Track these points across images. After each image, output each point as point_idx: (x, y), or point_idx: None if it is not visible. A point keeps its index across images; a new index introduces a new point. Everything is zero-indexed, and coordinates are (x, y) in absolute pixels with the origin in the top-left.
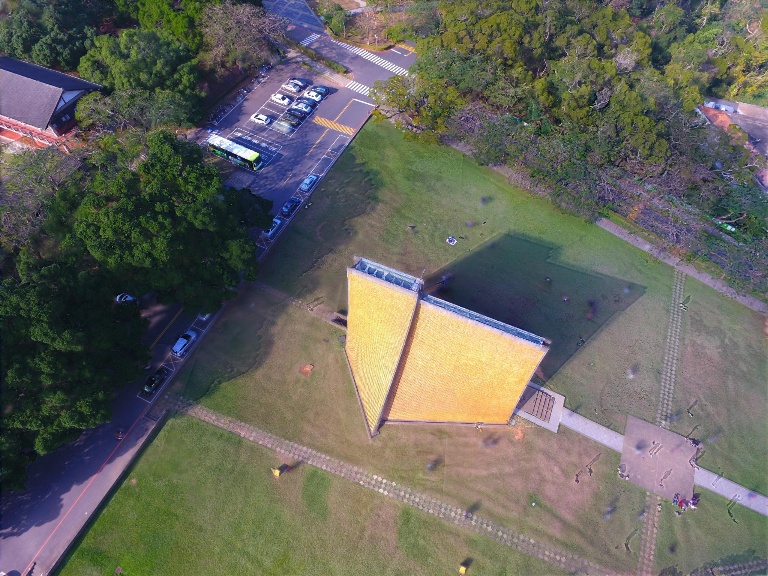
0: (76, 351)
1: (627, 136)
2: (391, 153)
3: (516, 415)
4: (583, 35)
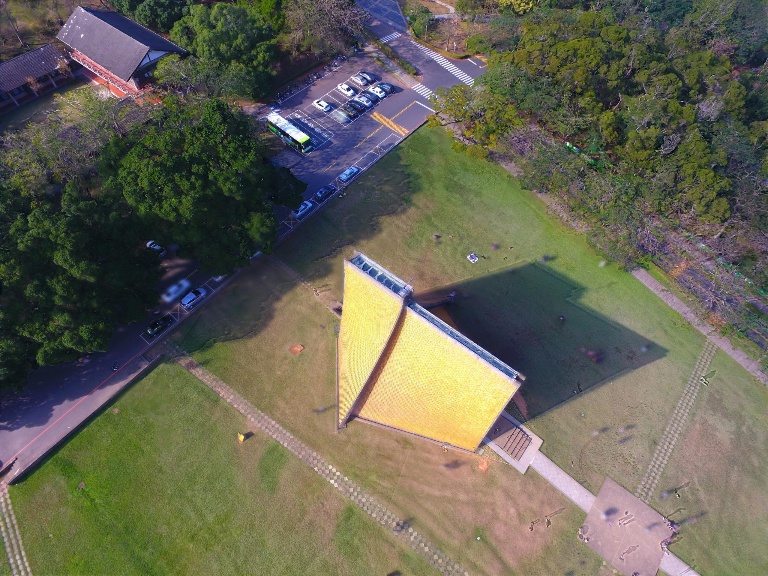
0: (90, 281)
1: (685, 188)
2: (437, 160)
3: (486, 445)
4: (669, 75)
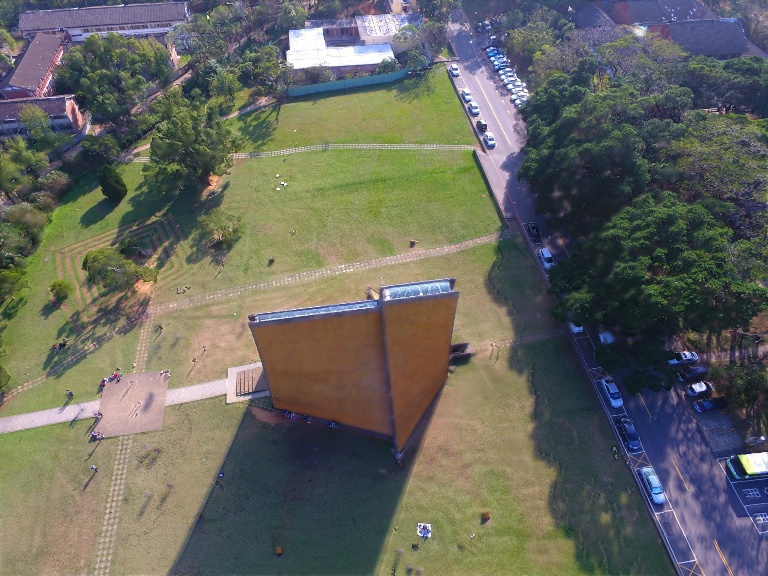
0: None
1: None
2: None
3: None
4: None
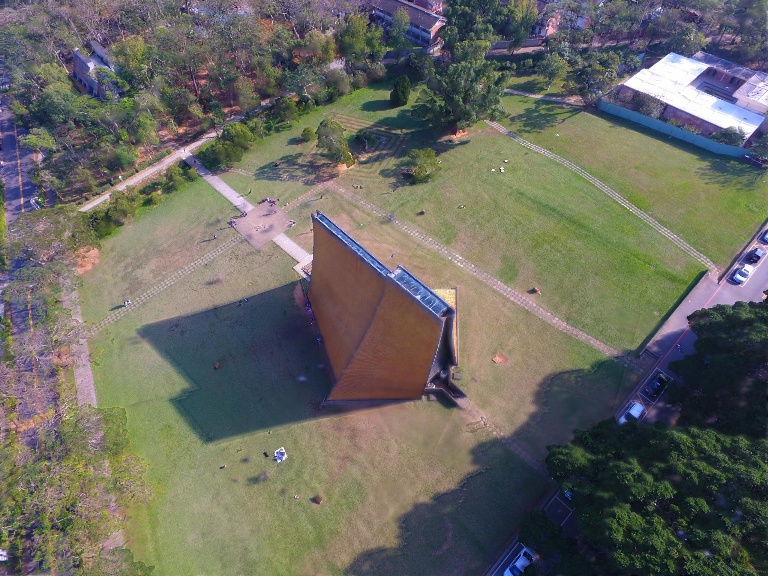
0: None
1: None
2: None
3: None
4: None
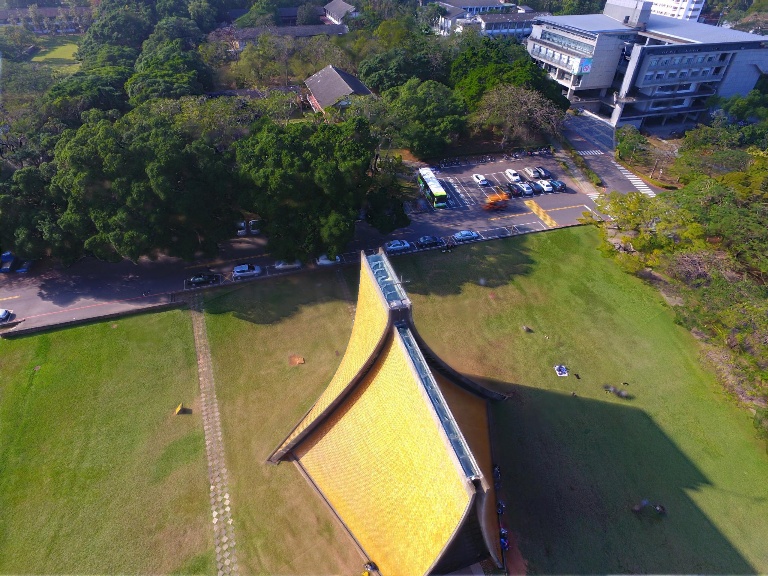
0: (161, 198)
1: None
2: (577, 260)
3: None
4: None
